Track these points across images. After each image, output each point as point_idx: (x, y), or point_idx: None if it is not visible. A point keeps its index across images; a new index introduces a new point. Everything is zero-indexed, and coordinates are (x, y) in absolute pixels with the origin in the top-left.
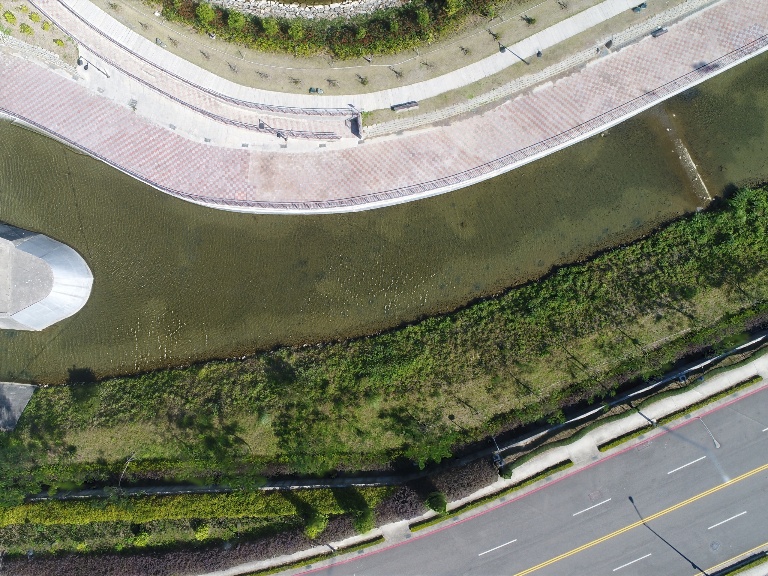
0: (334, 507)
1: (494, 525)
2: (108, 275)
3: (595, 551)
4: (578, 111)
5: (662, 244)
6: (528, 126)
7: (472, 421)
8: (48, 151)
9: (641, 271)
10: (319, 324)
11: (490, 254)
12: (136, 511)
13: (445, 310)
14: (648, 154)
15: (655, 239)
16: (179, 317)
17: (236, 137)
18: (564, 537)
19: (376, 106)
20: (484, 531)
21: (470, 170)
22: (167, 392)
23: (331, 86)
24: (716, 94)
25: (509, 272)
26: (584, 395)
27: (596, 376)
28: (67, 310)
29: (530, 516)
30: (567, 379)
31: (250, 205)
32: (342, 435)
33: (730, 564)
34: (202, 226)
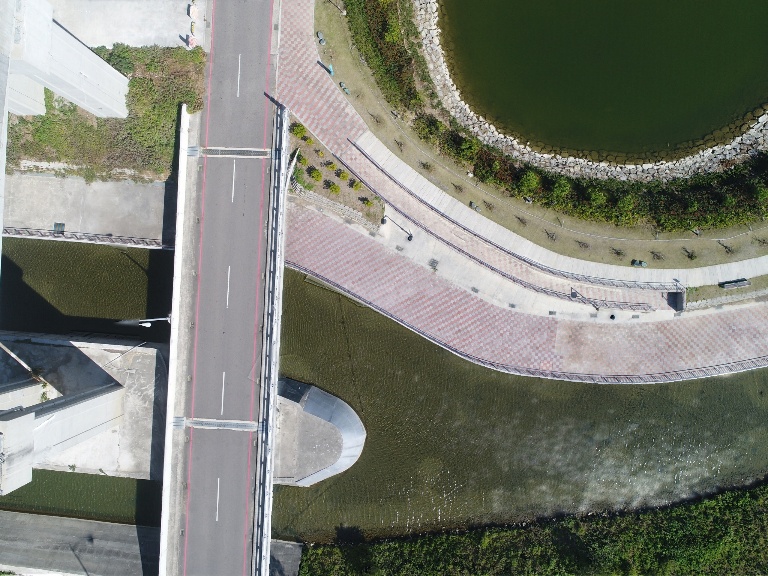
0: None
1: None
2: (381, 431)
3: None
4: None
5: None
6: None
7: None
8: (332, 305)
9: None
10: (604, 491)
11: None
12: None
13: (740, 483)
14: None
15: None
16: (455, 478)
17: (544, 304)
18: None
19: (703, 282)
20: None
21: None
22: (451, 563)
23: (655, 259)
24: None
25: None
26: None
27: None
28: (341, 469)
29: None
30: None
31: (556, 376)
32: None
33: None
34: (483, 384)
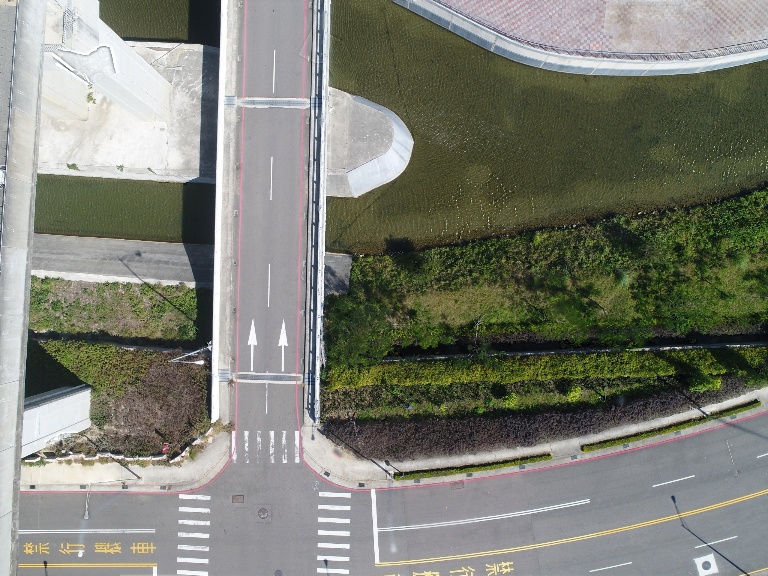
0: (715, 366)
1: None
2: (428, 140)
3: None
4: None
5: None
6: None
7: None
8: (378, 3)
9: None
10: (653, 191)
11: None
12: (505, 370)
13: None
14: None
15: None
16: (504, 184)
17: None
18: None
19: None
20: None
21: None
22: (503, 258)
23: None
24: None
25: None
26: None
27: None
28: (390, 174)
29: None
30: None
31: (606, 56)
32: (704, 298)
33: None
34: (529, 88)
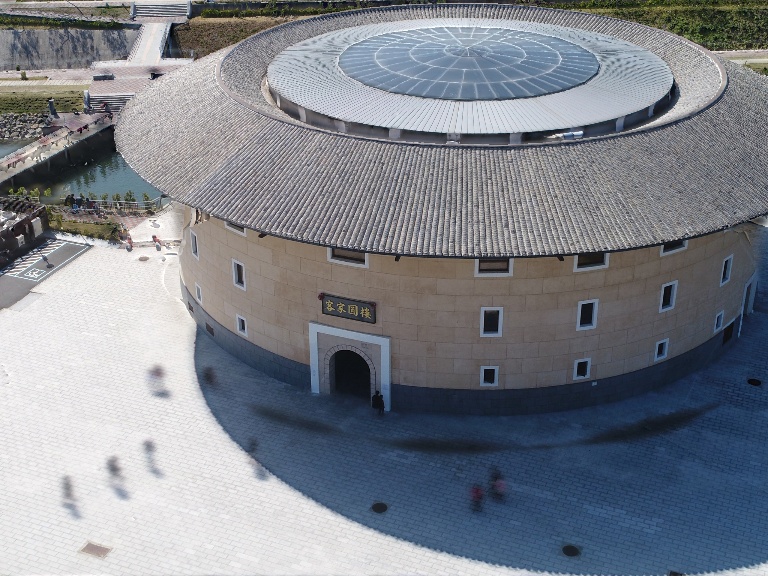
0: None
1: None
2: None
3: None
4: None
5: None
6: None
7: None
8: None
9: (767, 34)
10: None
11: None
12: None
13: None
14: None
15: (749, 48)
16: None
17: None
18: None
19: None
20: None
21: None
22: None
23: None
24: None
25: None
26: None
27: None
28: None
29: None
30: None
31: None
32: None
33: None
34: None
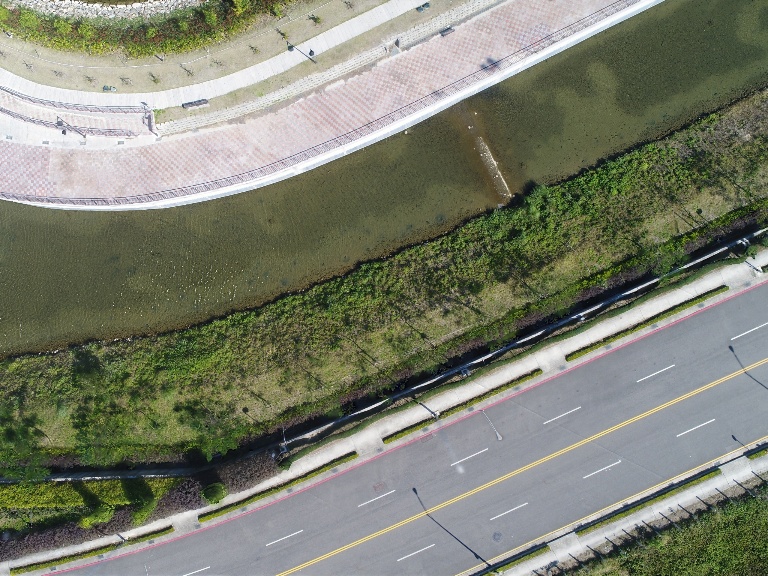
0: (120, 498)
1: (281, 516)
2: None
3: (380, 541)
4: (369, 109)
5: (460, 240)
6: (320, 124)
7: (266, 414)
8: None
9: (437, 267)
10: (130, 319)
11: (297, 250)
12: None
13: (253, 305)
14: (451, 151)
15: (455, 235)
16: None
17: (36, 134)
18: (349, 528)
19: (168, 104)
20: (271, 522)
21: (264, 167)
22: None
23: (124, 84)
24: (517, 92)
25: (315, 268)
26: (371, 388)
27: (385, 370)
28: None
29: (316, 507)
30: (357, 372)
31: (50, 201)
32: (139, 427)
33: (512, 554)
34: (17, 222)
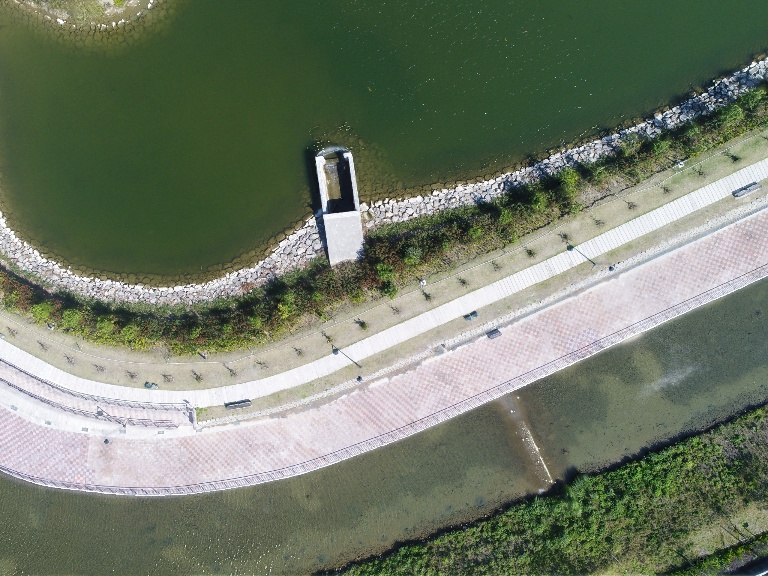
0: None
1: None
2: None
3: None
4: (413, 408)
5: (500, 530)
6: (363, 421)
7: None
8: None
9: (477, 559)
10: None
11: (335, 527)
12: None
13: None
14: (492, 434)
15: (495, 522)
16: None
17: (76, 421)
18: None
19: (210, 403)
20: None
21: (306, 462)
22: None
23: (166, 381)
24: (561, 377)
25: (353, 545)
26: None
27: None
28: None
29: None
30: None
31: (89, 489)
32: None
33: None
34: (52, 489)
